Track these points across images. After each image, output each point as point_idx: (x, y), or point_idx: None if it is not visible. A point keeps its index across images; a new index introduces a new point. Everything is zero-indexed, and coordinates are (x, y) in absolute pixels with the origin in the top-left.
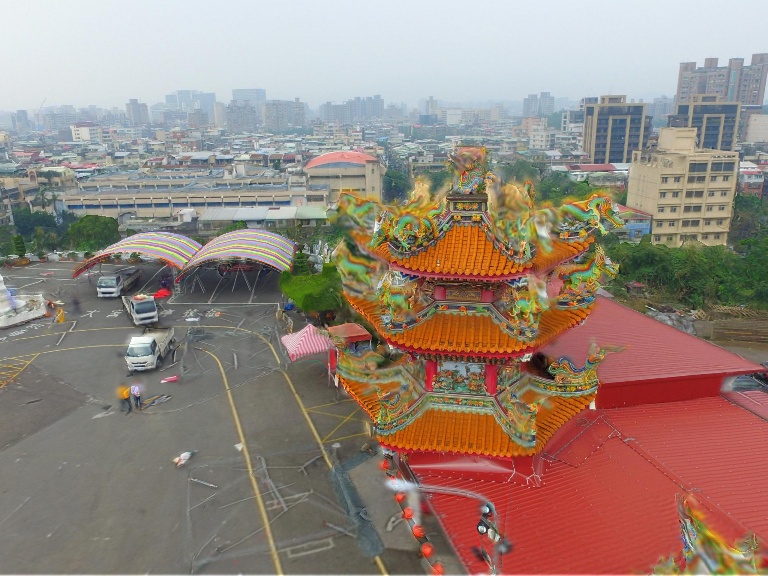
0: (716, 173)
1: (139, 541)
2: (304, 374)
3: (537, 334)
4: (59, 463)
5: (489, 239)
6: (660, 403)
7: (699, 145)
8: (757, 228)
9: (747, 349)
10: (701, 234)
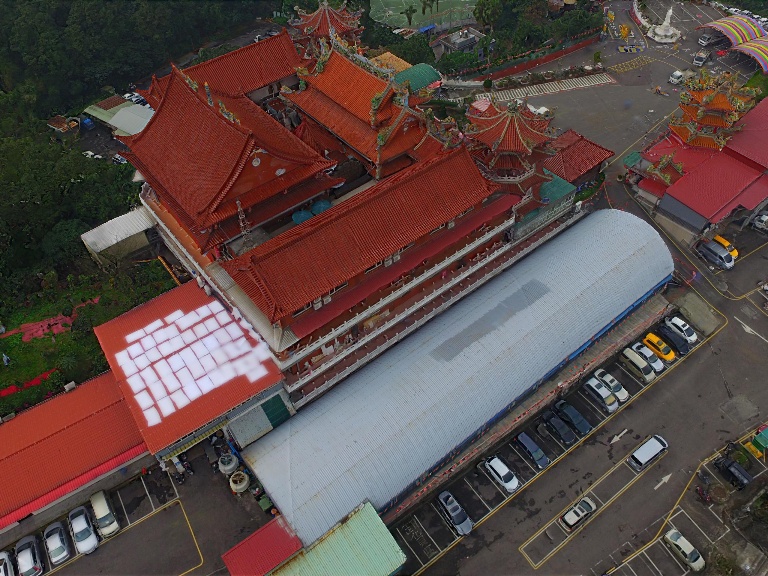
0: None
1: (626, 120)
2: None
3: None
4: (629, 96)
5: None
6: (740, 161)
7: None
8: None
9: None
10: None
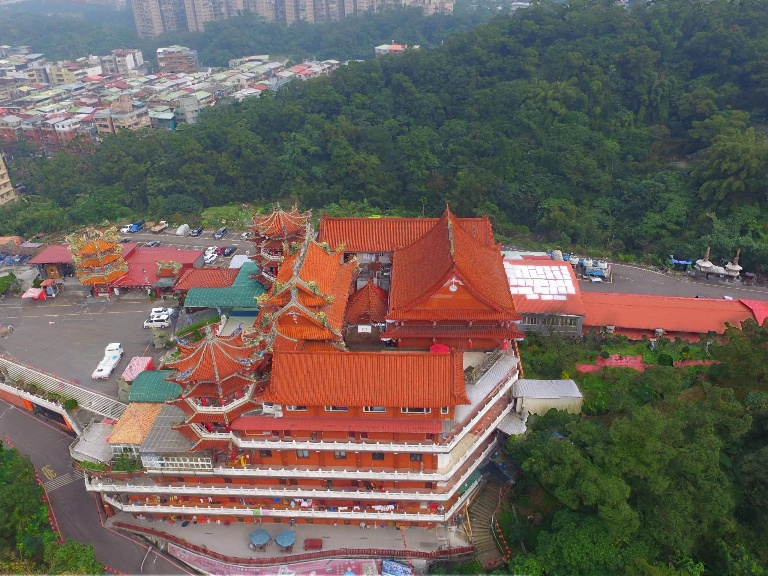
0: None
1: None
2: (32, 304)
3: None
4: None
5: (104, 242)
6: (131, 257)
7: None
8: (7, 166)
9: None
10: None
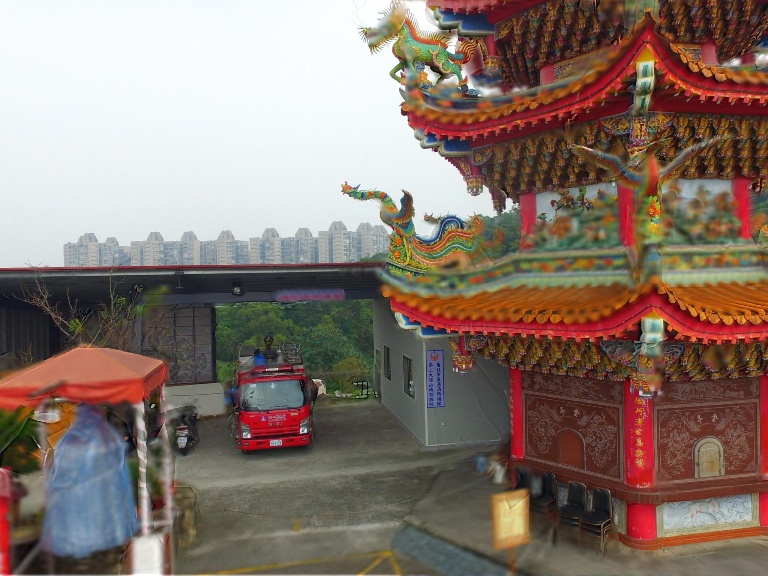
0: None
1: None
2: None
3: None
4: None
5: None
6: None
7: None
8: None
9: None
10: None
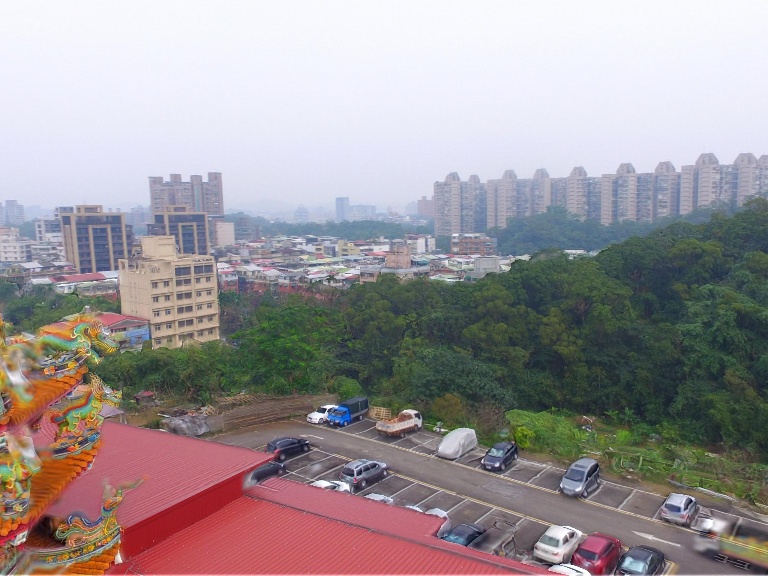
0: (199, 275)
1: None
2: None
3: (31, 502)
4: None
5: None
6: (190, 526)
7: (180, 251)
8: (241, 319)
9: (254, 433)
10: (197, 332)
